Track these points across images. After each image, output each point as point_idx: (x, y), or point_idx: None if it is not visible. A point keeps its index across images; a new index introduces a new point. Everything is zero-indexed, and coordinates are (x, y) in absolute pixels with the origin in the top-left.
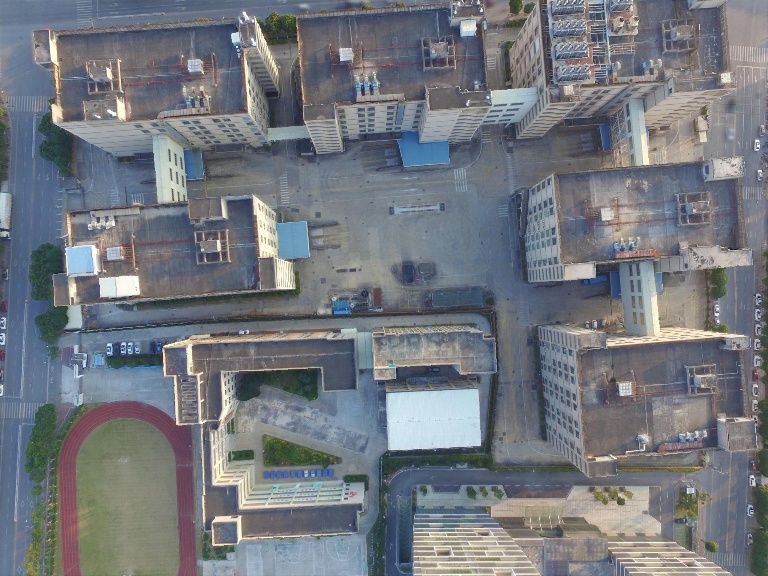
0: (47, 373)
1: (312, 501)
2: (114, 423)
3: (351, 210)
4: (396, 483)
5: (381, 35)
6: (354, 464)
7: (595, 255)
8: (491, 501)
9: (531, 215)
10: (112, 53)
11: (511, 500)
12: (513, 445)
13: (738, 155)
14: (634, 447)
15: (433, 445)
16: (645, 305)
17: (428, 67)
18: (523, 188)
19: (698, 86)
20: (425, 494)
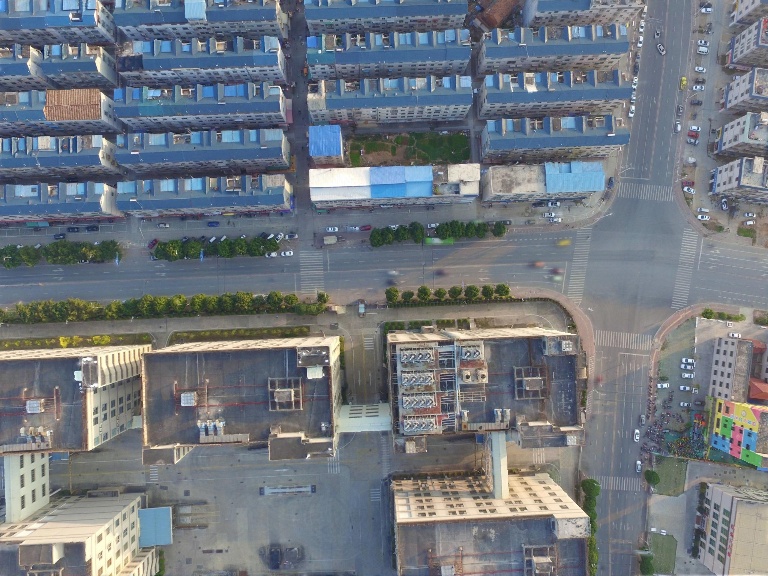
0: None
1: None
2: None
3: (220, 489)
4: None
5: (229, 372)
6: None
7: None
8: None
9: None
10: None
11: None
12: None
13: (617, 444)
14: None
15: None
16: None
17: (273, 410)
18: (397, 472)
19: (546, 443)
20: None
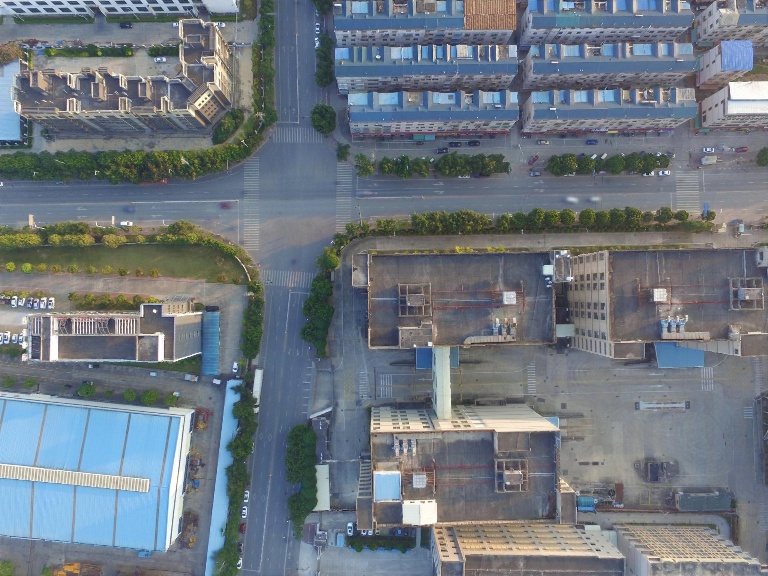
0: (286, 548)
1: None
2: None
3: (597, 403)
4: None
5: (688, 271)
6: None
7: None
8: None
9: None
10: (422, 275)
11: None
12: None
13: None
14: None
15: None
16: None
17: (736, 308)
18: None
19: None
20: None
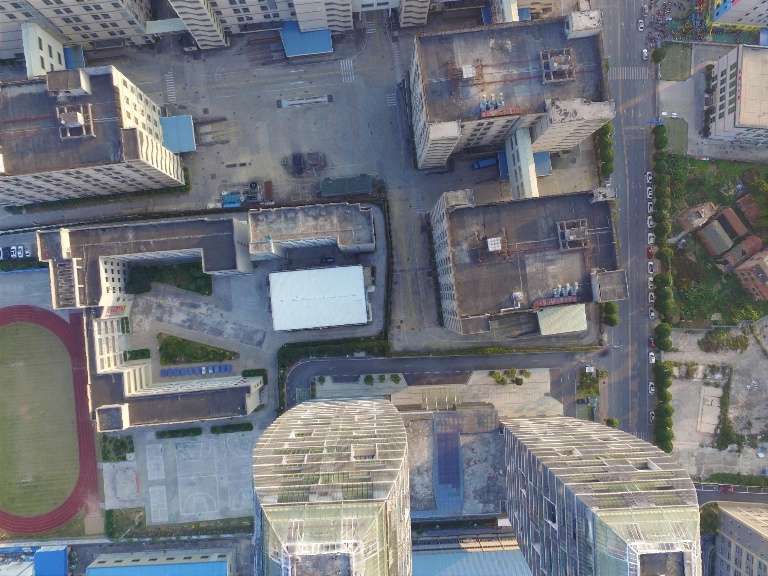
0: None
1: (201, 388)
2: (7, 328)
3: (239, 105)
4: (295, 375)
5: None
6: (252, 359)
7: (462, 116)
8: (391, 389)
9: (412, 96)
10: None
11: (411, 387)
12: (411, 333)
13: (623, 36)
14: (509, 305)
15: (318, 323)
16: (523, 173)
17: None
18: None
19: None
20: (322, 383)
